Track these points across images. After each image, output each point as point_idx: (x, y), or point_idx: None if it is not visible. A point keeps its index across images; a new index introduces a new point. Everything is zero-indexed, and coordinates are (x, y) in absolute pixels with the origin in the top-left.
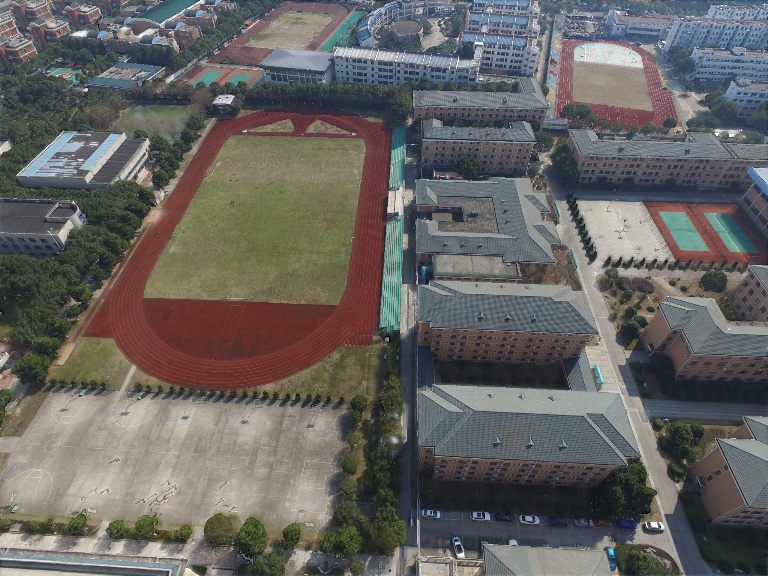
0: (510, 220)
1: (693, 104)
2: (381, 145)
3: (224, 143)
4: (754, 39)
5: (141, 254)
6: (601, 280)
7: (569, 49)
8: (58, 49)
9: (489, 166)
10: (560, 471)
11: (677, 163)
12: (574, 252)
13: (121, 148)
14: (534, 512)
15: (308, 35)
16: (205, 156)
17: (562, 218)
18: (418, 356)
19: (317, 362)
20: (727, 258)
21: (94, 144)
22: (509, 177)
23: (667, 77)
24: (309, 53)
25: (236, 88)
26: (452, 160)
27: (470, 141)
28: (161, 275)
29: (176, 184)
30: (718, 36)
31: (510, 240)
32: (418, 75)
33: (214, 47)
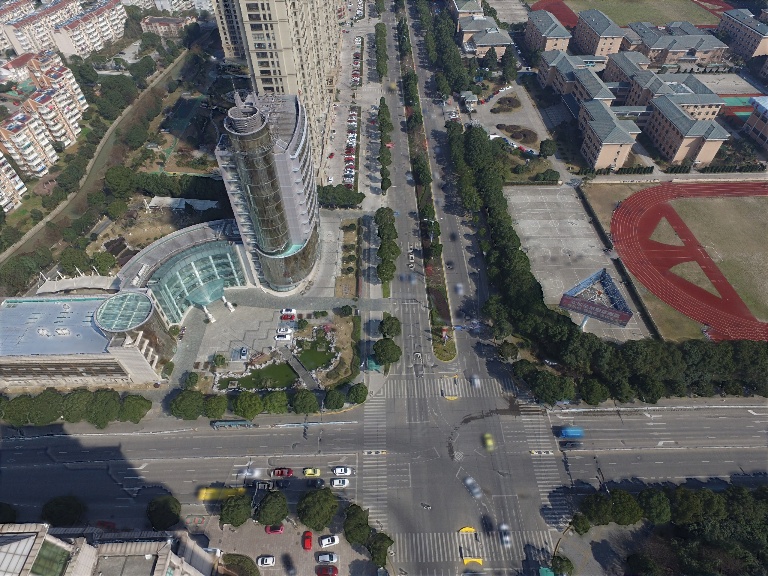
0: None
1: None
2: None
3: None
4: None
5: None
6: None
7: None
8: None
9: (738, 47)
10: (536, 41)
11: None
12: None
13: None
14: (522, 53)
15: None
16: None
17: (709, 69)
18: None
19: None
20: (723, 109)
21: None
22: None
23: None
24: None
25: None
26: None
27: None
28: (575, 1)
29: None
30: None
31: None
32: None
33: None
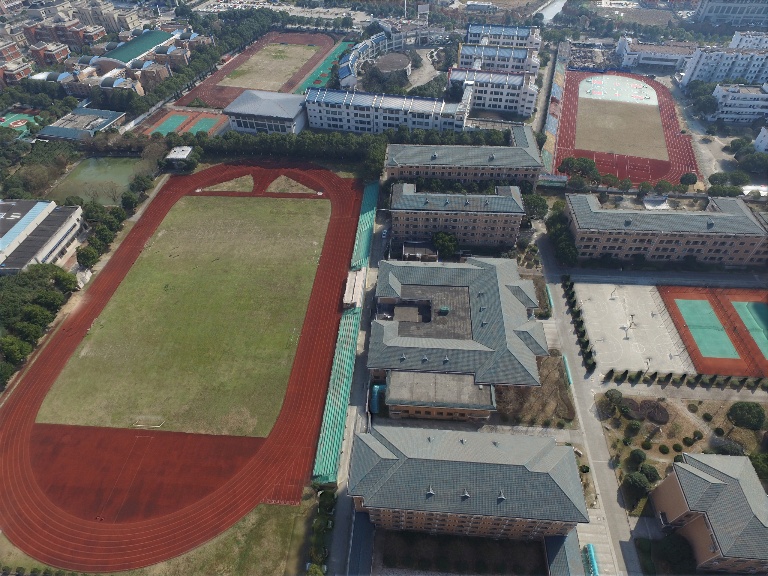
0: (487, 322)
1: (716, 151)
2: (349, 208)
3: (172, 206)
4: None
5: (46, 358)
6: (601, 402)
7: (574, 83)
8: (15, 94)
9: (471, 238)
10: None
11: (697, 238)
12: (568, 359)
13: (47, 219)
14: None
15: (287, 71)
16: (148, 223)
17: (555, 309)
18: (354, 528)
19: (227, 528)
20: (763, 370)
21: (16, 216)
22: (494, 251)
23: (685, 117)
24: (279, 96)
25: (194, 139)
26: (426, 231)
27: (446, 212)
28: (63, 389)
29: (108, 261)
30: (745, 68)
31: (484, 353)
32: (398, 121)
33: (184, 87)
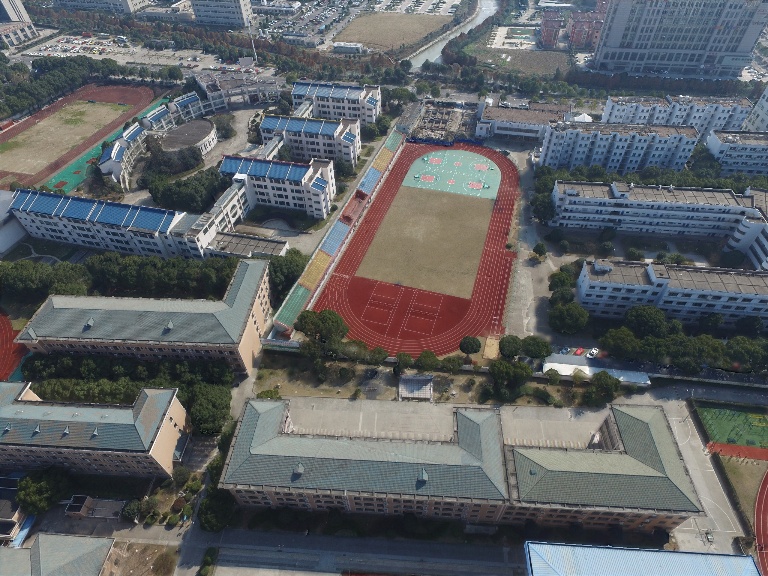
0: None
1: (540, 281)
2: None
3: None
4: (660, 154)
5: None
6: None
7: (405, 163)
8: None
9: (102, 467)
10: None
11: None
12: None
13: None
14: None
15: (68, 143)
16: None
17: None
18: None
19: None
20: None
21: None
22: (133, 491)
23: (522, 219)
24: None
25: None
26: (34, 460)
27: (33, 447)
28: None
29: None
30: (607, 149)
31: None
32: (125, 237)
33: None
